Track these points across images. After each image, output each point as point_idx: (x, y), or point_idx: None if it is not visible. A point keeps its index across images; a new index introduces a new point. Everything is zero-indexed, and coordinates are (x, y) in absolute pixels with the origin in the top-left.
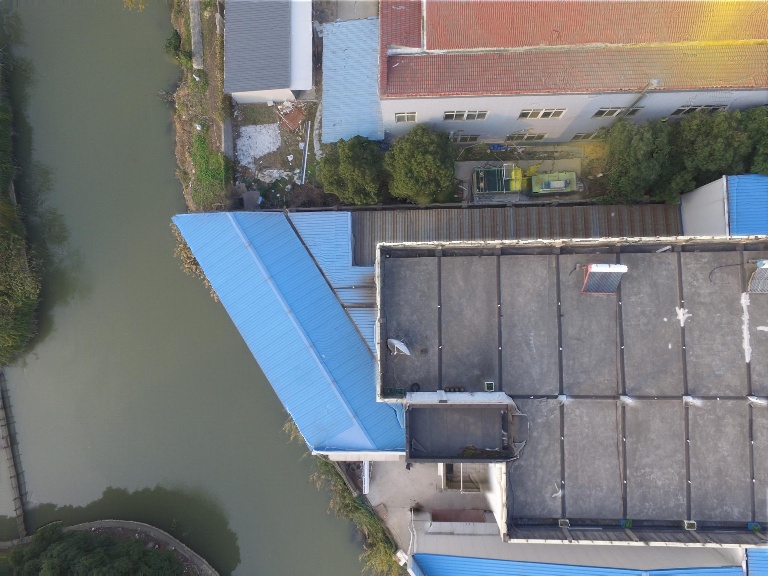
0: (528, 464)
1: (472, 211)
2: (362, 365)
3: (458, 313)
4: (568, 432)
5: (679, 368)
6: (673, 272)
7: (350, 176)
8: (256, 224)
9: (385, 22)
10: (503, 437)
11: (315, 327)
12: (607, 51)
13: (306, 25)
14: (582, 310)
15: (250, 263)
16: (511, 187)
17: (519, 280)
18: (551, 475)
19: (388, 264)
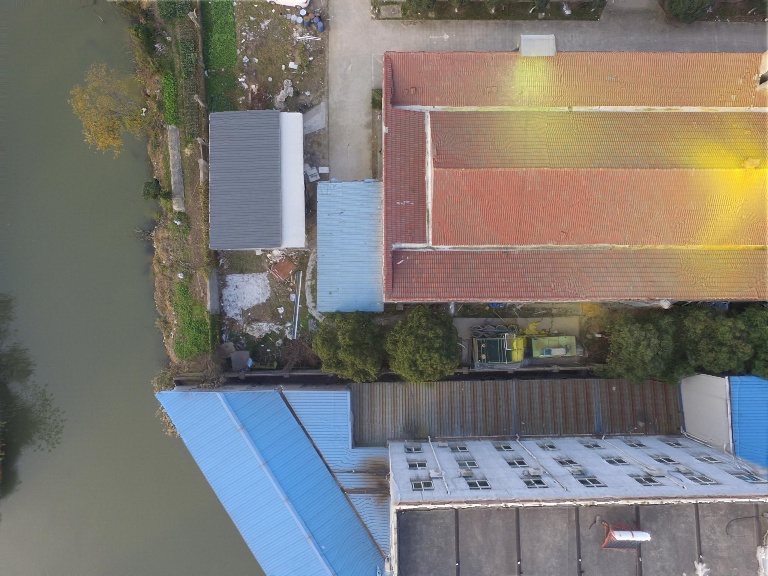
0: None
1: (474, 384)
2: (362, 543)
3: (477, 570)
4: None
5: None
6: (691, 525)
7: (350, 362)
8: (249, 404)
9: (389, 220)
10: None
11: (314, 515)
12: (614, 253)
13: (298, 178)
14: (602, 566)
15: (243, 447)
16: (513, 357)
17: (539, 534)
18: None
19: (403, 518)
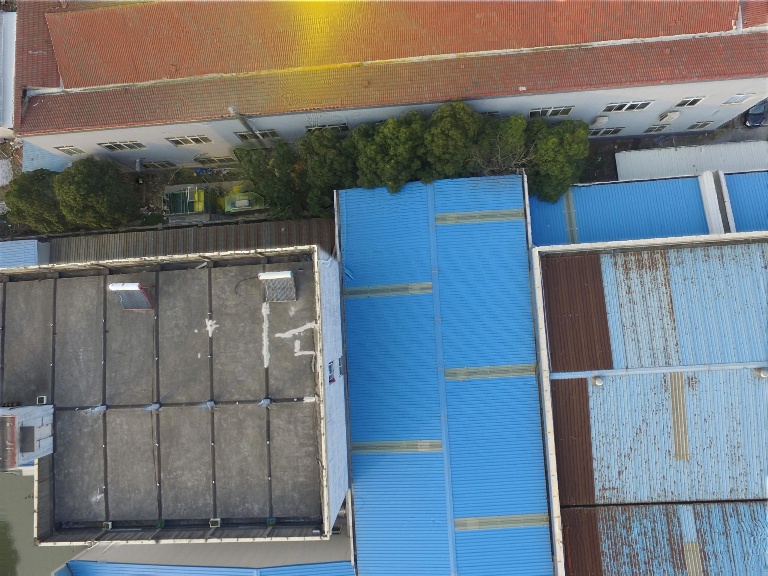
0: (76, 471)
1: (157, 233)
2: None
3: (19, 333)
4: (110, 440)
5: (206, 376)
6: (204, 286)
7: (24, 207)
8: None
9: (20, 66)
10: (6, 447)
11: None
12: (221, 81)
13: None
14: (124, 326)
15: None
16: (195, 208)
17: (72, 300)
18: (96, 481)
19: None
